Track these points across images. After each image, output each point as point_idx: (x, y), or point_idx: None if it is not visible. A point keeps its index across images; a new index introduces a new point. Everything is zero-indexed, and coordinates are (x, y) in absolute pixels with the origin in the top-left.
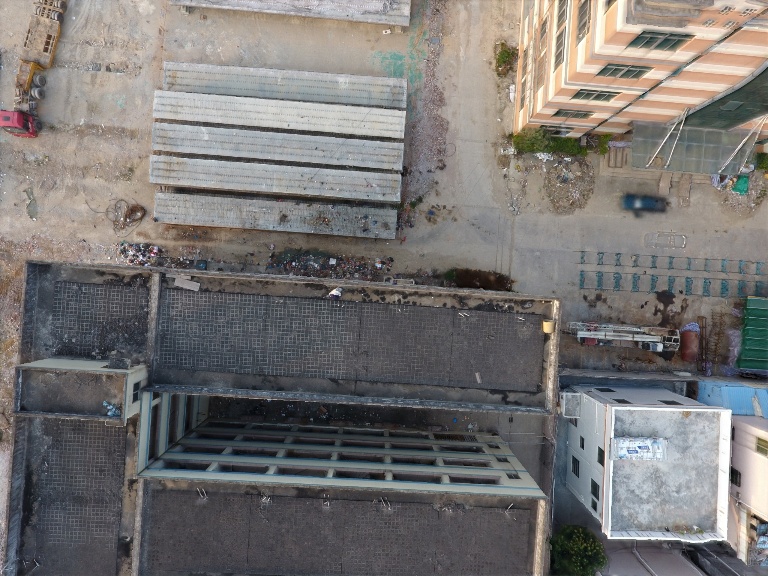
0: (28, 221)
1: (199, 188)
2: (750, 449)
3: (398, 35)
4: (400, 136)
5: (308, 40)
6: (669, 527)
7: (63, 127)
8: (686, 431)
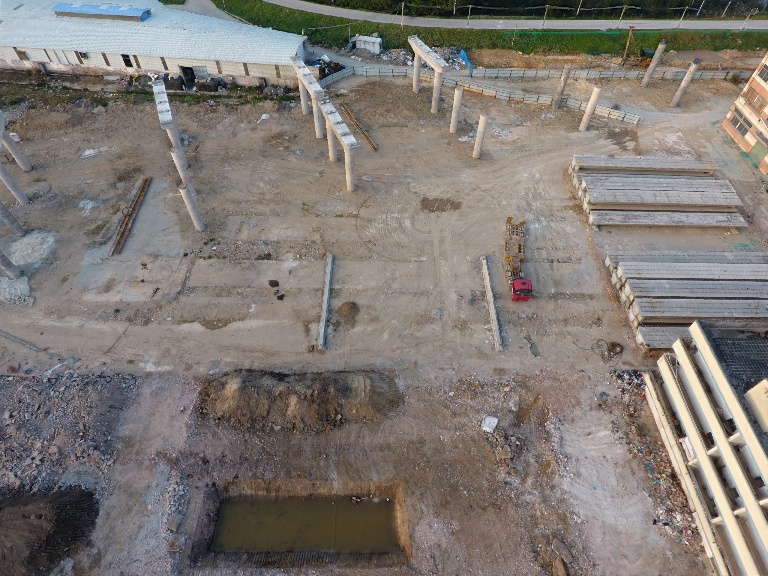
0: (533, 359)
1: (668, 322)
2: None
3: (736, 235)
4: None
5: (681, 240)
6: None
7: (540, 295)
8: None
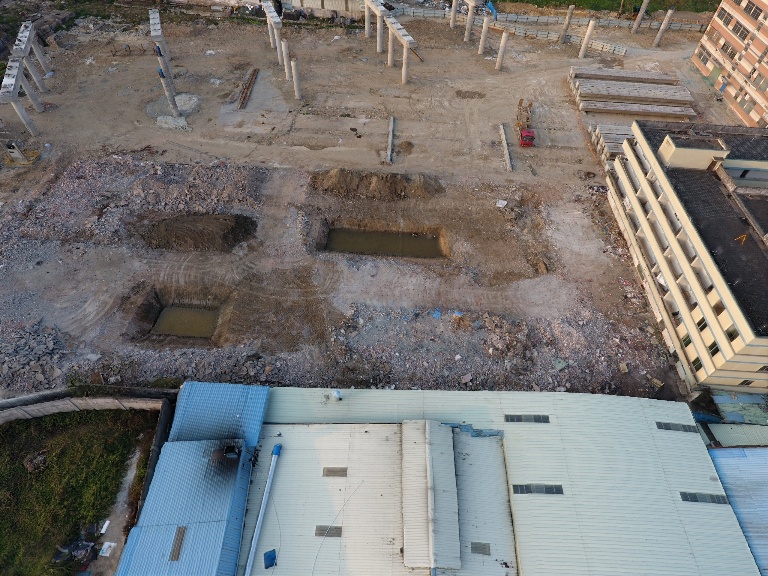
0: (533, 177)
1: None
2: None
3: None
4: None
5: None
6: None
7: (540, 146)
8: None
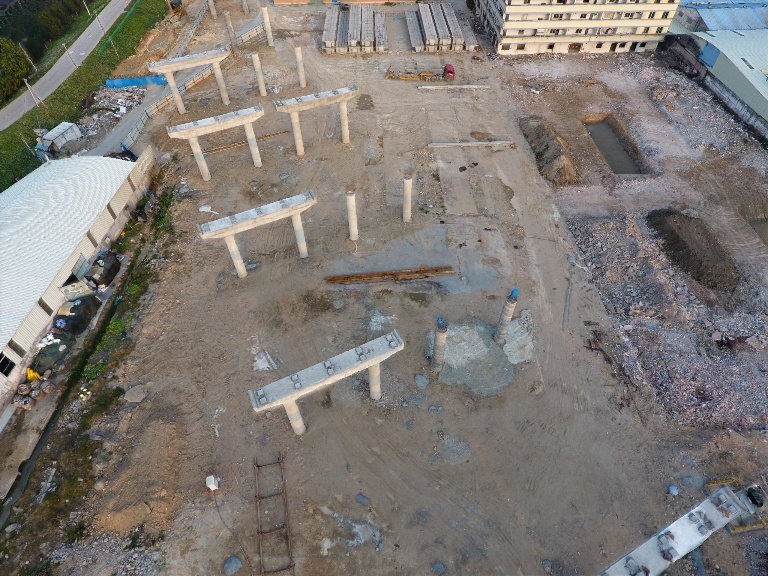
0: None
1: None
2: None
3: None
4: (428, 4)
5: (392, 32)
6: None
7: None
8: None
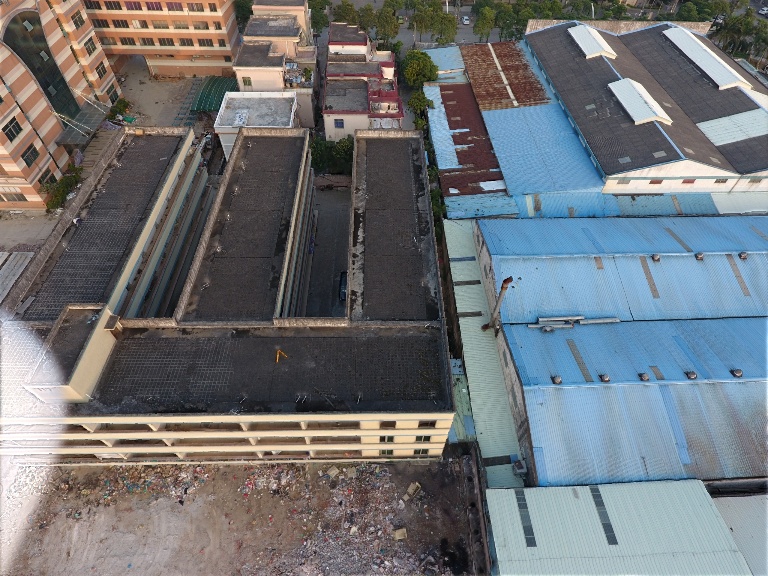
0: None
1: None
2: (252, 89)
3: None
4: (7, 255)
5: None
6: (291, 111)
7: None
8: (238, 108)
